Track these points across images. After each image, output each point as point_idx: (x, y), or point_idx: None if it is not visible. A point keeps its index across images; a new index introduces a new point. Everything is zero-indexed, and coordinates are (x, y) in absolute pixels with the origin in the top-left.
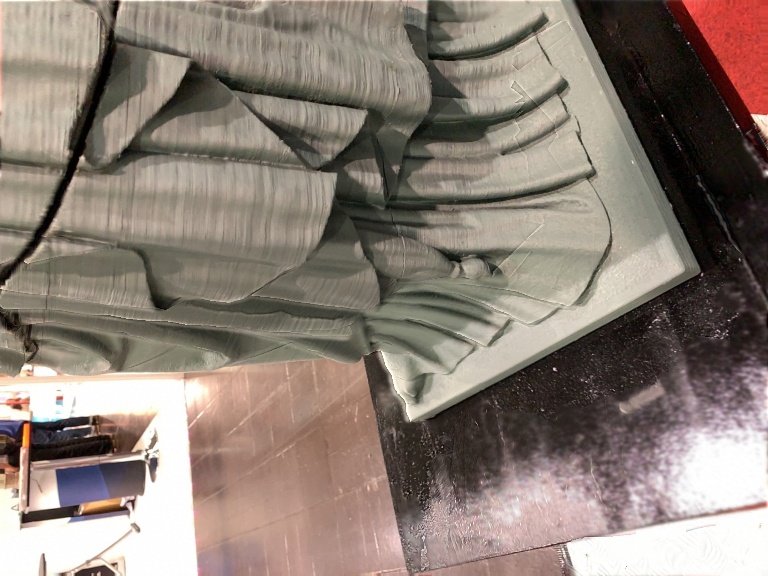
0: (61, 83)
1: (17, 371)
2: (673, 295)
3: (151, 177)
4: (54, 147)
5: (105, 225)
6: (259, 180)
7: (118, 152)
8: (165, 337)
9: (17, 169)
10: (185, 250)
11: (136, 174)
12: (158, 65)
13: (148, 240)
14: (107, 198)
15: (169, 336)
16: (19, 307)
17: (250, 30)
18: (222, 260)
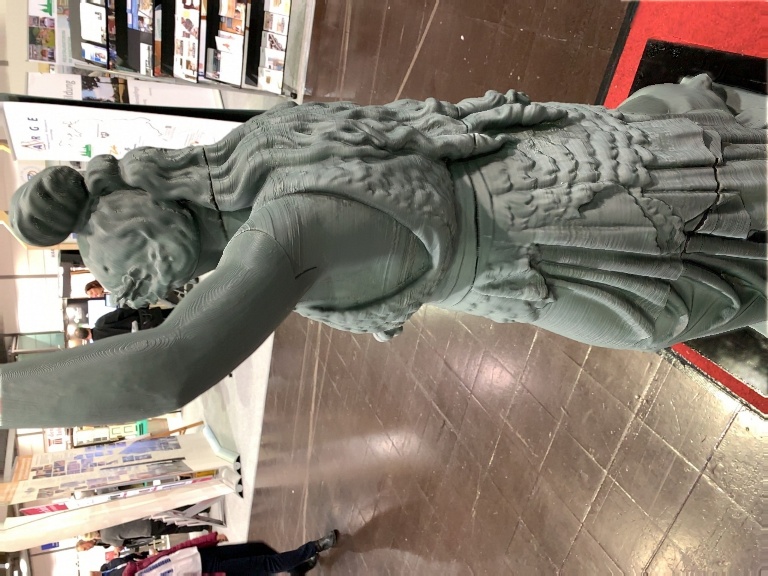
0: (696, 138)
1: (652, 331)
2: None
3: (736, 165)
4: (711, 156)
5: (736, 183)
6: (766, 162)
7: (722, 159)
8: (721, 284)
9: (701, 168)
10: (758, 195)
11: (731, 165)
12: (708, 132)
13: (749, 189)
14: (729, 175)
15: (722, 283)
16: (692, 250)
17: (707, 126)
18: (767, 201)
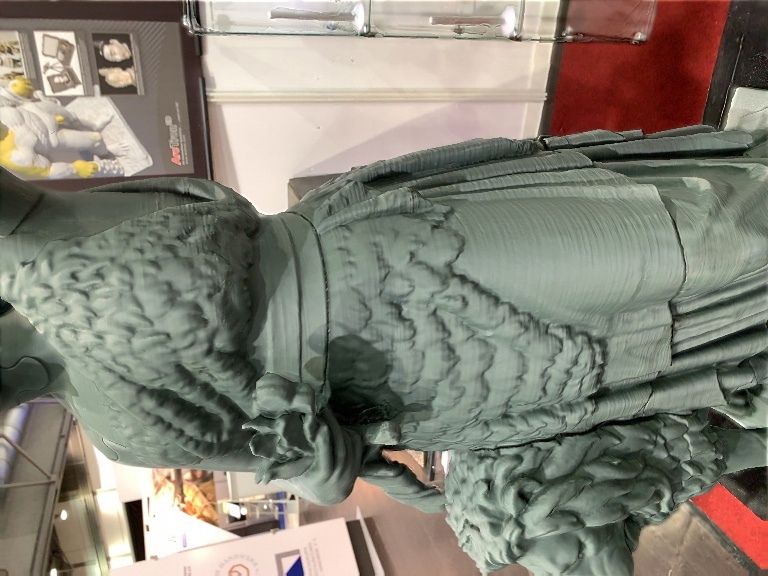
0: None
1: None
2: (764, 86)
3: None
4: None
5: None
6: None
7: None
8: None
9: None
10: None
11: None
12: None
13: None
14: None
15: None
16: None
17: None
18: None
